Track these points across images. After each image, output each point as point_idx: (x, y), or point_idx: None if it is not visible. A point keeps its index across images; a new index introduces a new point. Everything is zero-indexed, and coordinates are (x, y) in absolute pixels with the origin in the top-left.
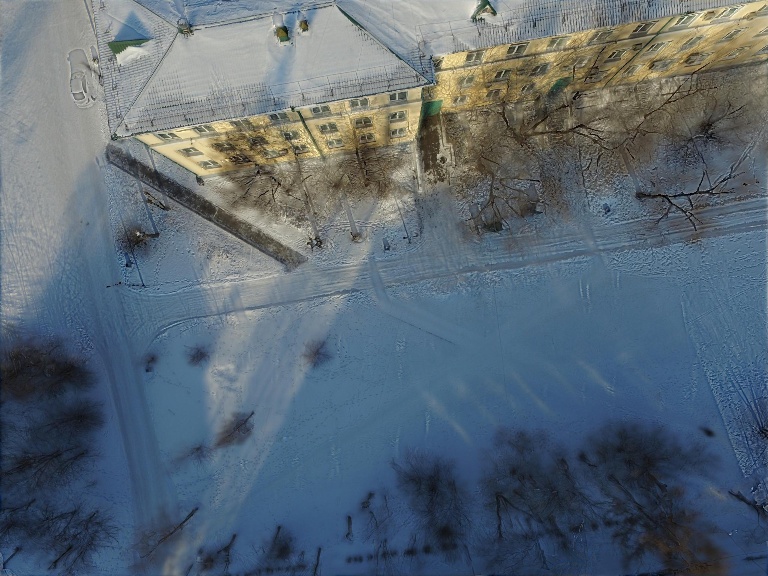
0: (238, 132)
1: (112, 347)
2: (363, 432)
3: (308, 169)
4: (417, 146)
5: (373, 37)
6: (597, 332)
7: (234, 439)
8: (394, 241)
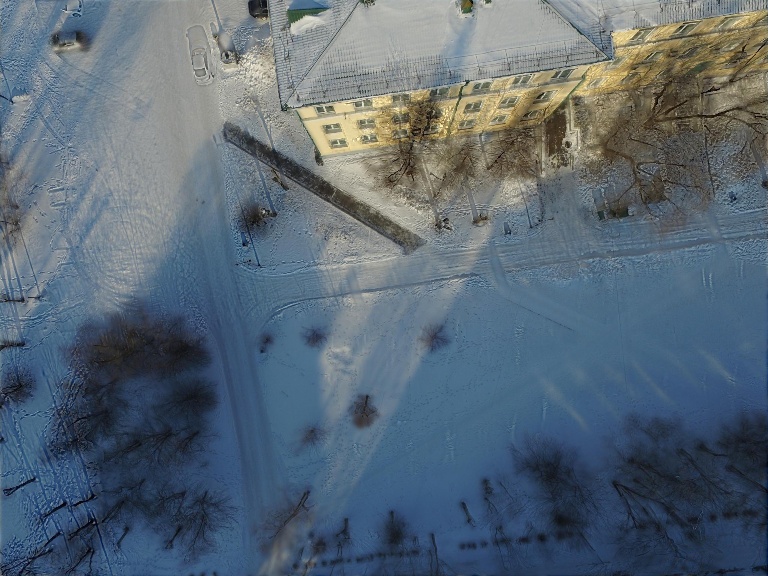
0: (392, 108)
1: (225, 327)
2: (479, 418)
3: (429, 151)
4: (544, 129)
5: (555, 11)
6: (719, 321)
7: (348, 422)
8: (515, 225)
